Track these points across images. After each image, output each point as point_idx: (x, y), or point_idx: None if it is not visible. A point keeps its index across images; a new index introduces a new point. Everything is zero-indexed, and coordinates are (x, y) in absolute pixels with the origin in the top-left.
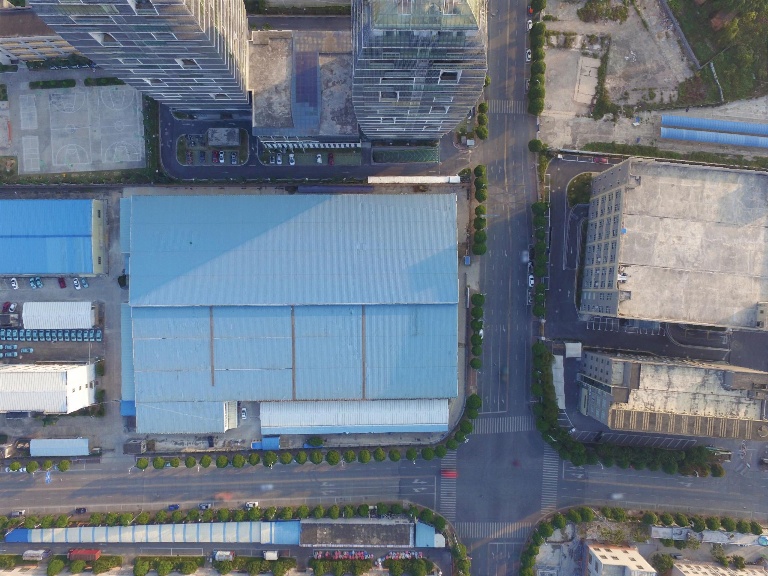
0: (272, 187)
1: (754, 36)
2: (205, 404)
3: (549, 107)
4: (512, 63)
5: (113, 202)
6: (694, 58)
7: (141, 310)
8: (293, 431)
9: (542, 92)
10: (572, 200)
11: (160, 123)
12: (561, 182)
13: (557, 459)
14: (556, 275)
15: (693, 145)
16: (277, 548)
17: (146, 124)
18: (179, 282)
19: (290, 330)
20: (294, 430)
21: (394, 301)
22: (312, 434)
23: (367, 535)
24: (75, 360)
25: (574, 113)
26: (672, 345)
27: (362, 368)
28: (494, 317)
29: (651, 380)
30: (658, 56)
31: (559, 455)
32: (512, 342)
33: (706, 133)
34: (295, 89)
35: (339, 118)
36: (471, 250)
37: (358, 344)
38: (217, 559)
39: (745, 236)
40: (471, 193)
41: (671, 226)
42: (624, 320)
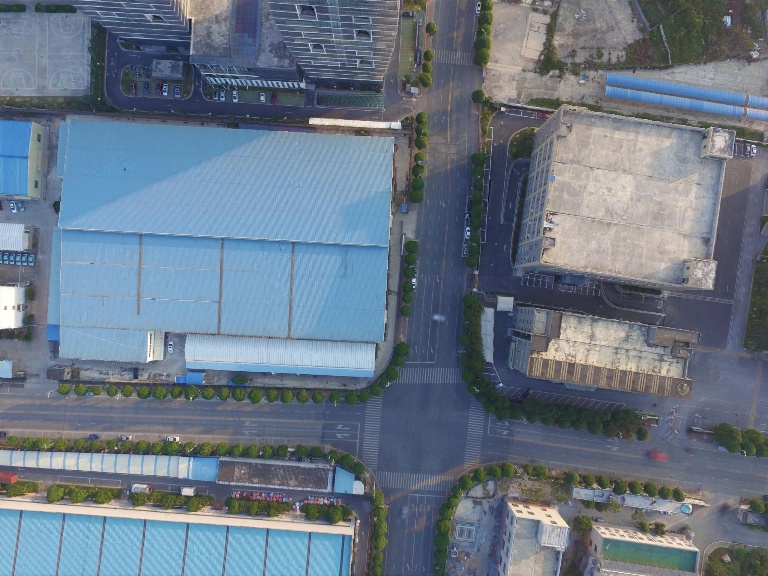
0: (214, 123)
1: (705, 1)
2: (129, 332)
3: (496, 60)
4: (462, 14)
5: (55, 128)
6: (644, 20)
7: (71, 233)
8: (217, 367)
9: (487, 42)
10: (513, 154)
11: (107, 52)
12: (504, 136)
13: (483, 414)
14: (493, 228)
15: (638, 106)
16: (195, 485)
17: (91, 51)
18: (110, 207)
19: (219, 263)
20: (219, 366)
21: (324, 240)
22: (238, 372)
23: (285, 476)
24: (6, 283)
25: (521, 68)
26: (606, 306)
27: (289, 306)
28: (428, 267)
29: (574, 332)
30: (608, 16)
31: (484, 408)
32: (445, 293)
33: (651, 94)
34: (235, 19)
35: (277, 51)
36: (408, 197)
37: (286, 281)
38: (133, 491)
39: (676, 192)
40: (412, 141)
41: (602, 177)
42: (559, 278)
